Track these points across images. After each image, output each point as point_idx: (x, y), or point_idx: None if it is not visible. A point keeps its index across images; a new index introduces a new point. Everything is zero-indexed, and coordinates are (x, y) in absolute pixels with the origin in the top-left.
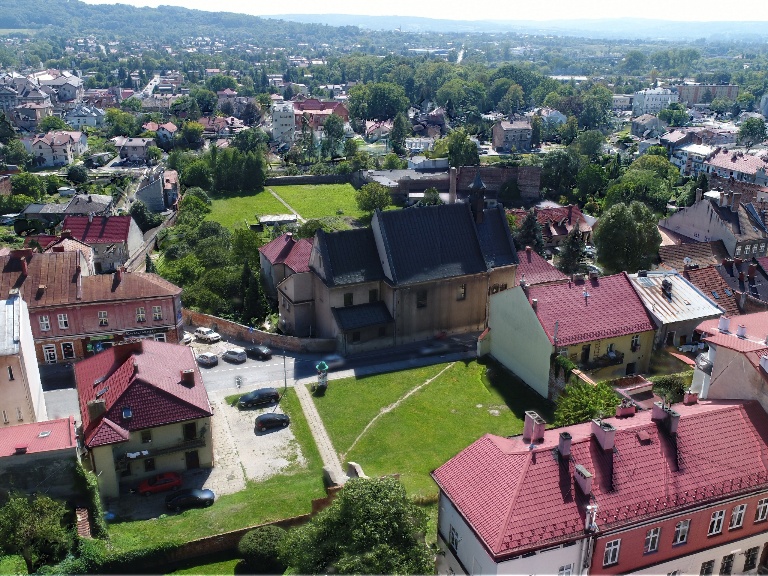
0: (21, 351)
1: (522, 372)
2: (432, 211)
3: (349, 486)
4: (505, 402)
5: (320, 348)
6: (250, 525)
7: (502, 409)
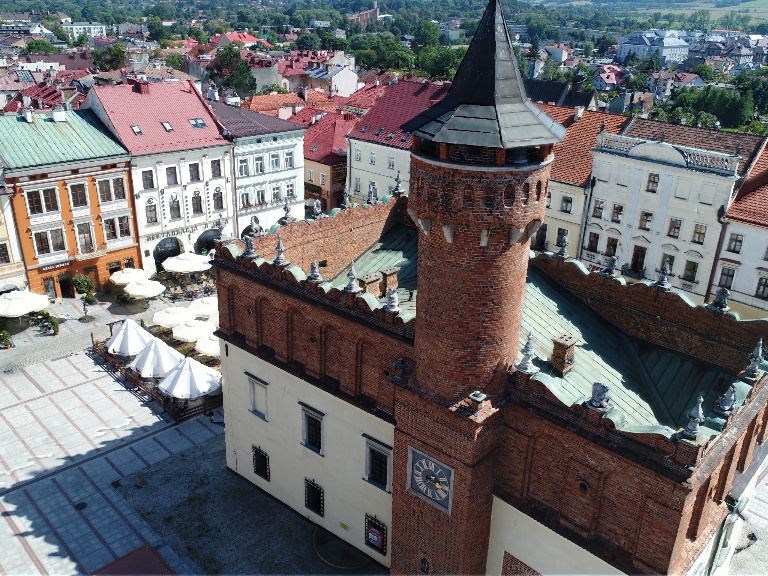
0: (332, 81)
1: None
2: (542, 83)
3: None
4: None
5: None
6: None
7: None
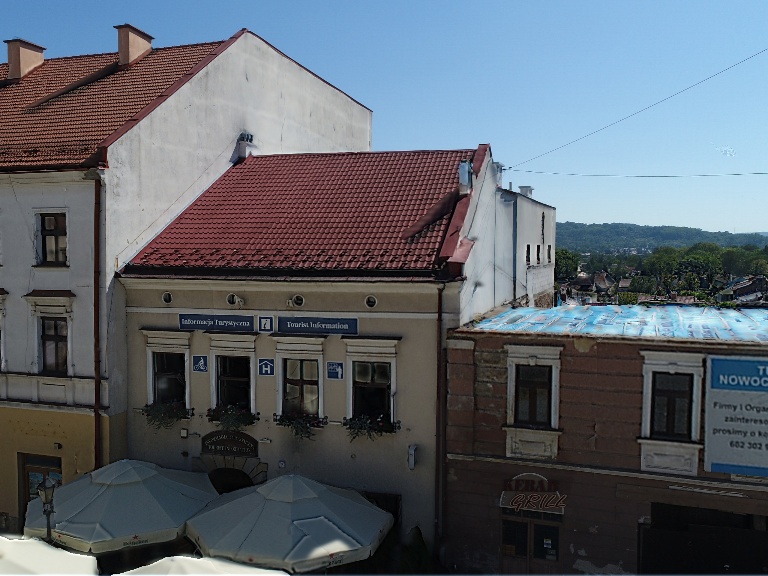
0: None
1: None
2: None
3: None
4: None
5: None
6: None
7: None
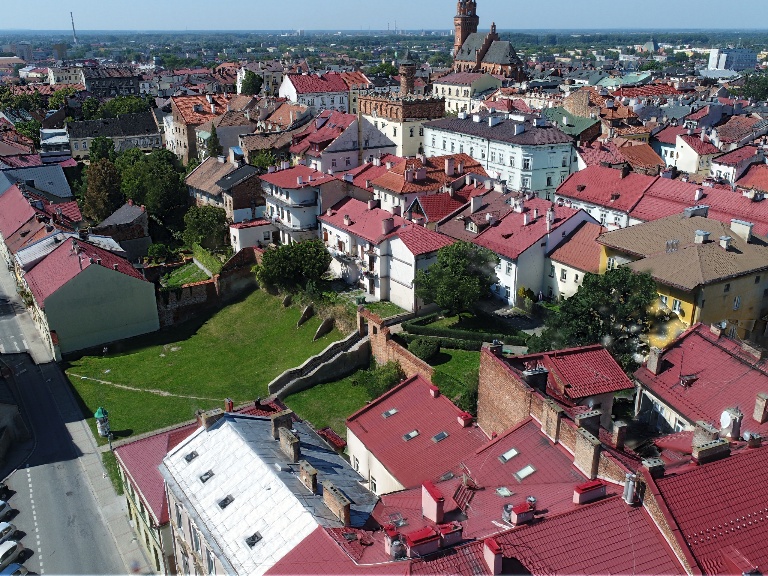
0: None
1: (120, 333)
2: None
3: (464, 246)
4: (160, 345)
5: (4, 449)
6: (396, 370)
7: (171, 346)
